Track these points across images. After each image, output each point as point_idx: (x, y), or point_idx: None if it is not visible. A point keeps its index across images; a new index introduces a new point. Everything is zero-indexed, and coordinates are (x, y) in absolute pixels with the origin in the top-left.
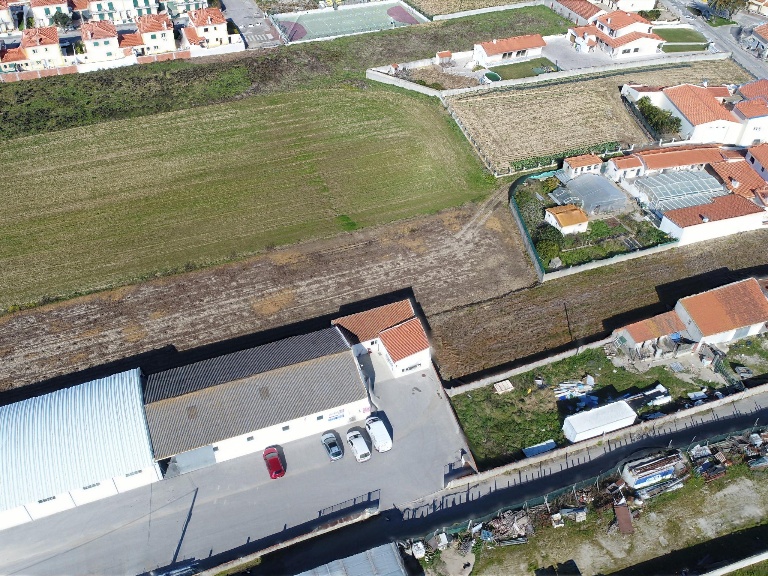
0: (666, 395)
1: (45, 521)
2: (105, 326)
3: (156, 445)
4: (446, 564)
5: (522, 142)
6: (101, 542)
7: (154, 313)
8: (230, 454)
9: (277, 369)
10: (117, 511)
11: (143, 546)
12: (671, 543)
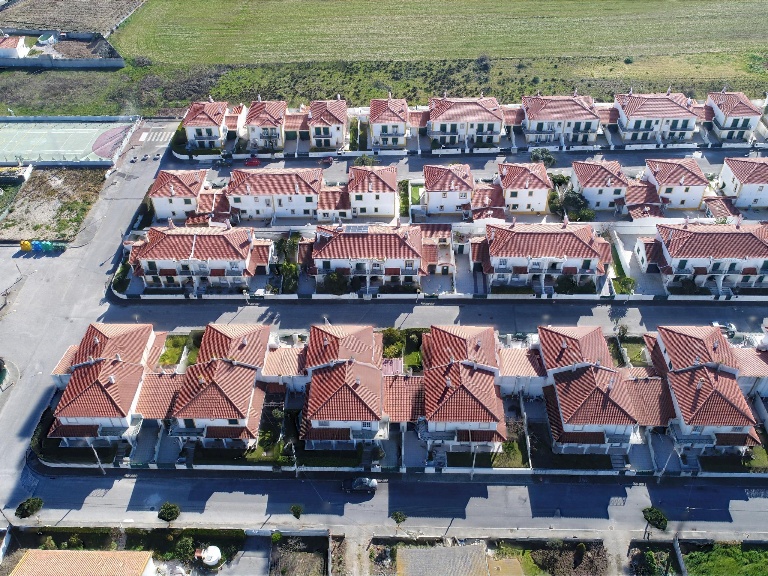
0: None
1: None
2: None
3: None
4: None
5: (108, 5)
6: None
7: None
8: None
9: None
10: None
11: None
12: None
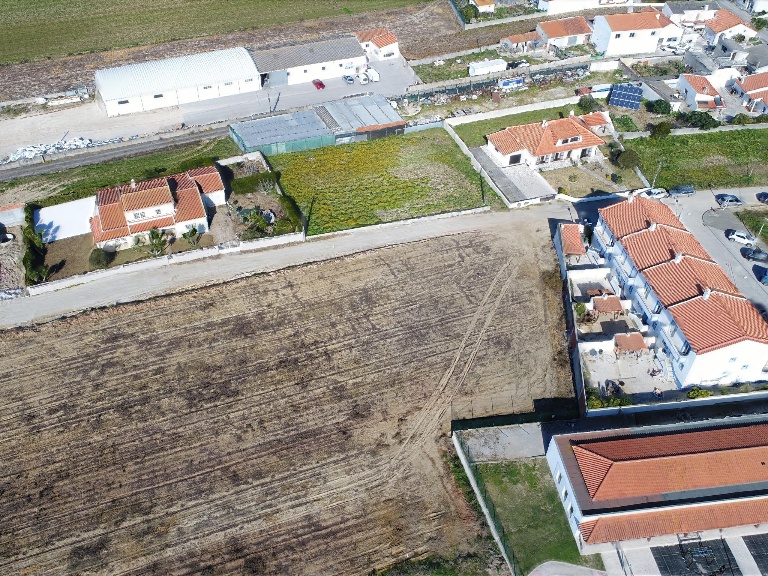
0: (526, 63)
1: (206, 101)
2: (212, 47)
3: (259, 67)
4: (407, 110)
5: None
6: (236, 106)
7: (239, 43)
8: (295, 79)
9: (317, 42)
10: (241, 98)
11: (257, 107)
12: (519, 105)
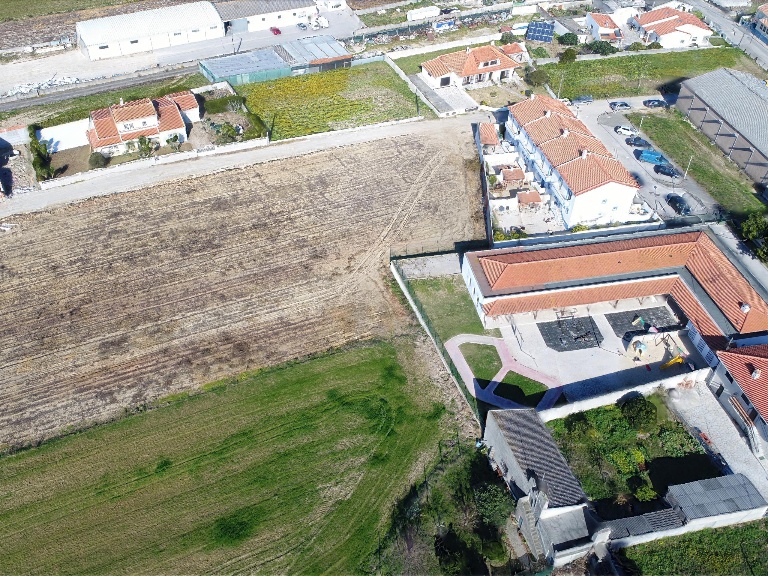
0: (458, 10)
1: (177, 46)
2: None
3: (222, 16)
4: (354, 49)
5: None
6: (204, 50)
7: None
8: (255, 27)
9: None
10: (208, 43)
11: (223, 50)
12: None
